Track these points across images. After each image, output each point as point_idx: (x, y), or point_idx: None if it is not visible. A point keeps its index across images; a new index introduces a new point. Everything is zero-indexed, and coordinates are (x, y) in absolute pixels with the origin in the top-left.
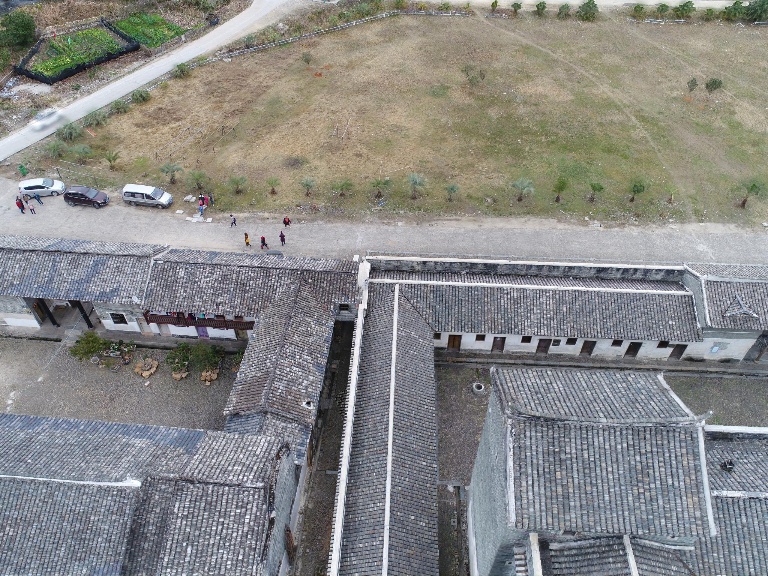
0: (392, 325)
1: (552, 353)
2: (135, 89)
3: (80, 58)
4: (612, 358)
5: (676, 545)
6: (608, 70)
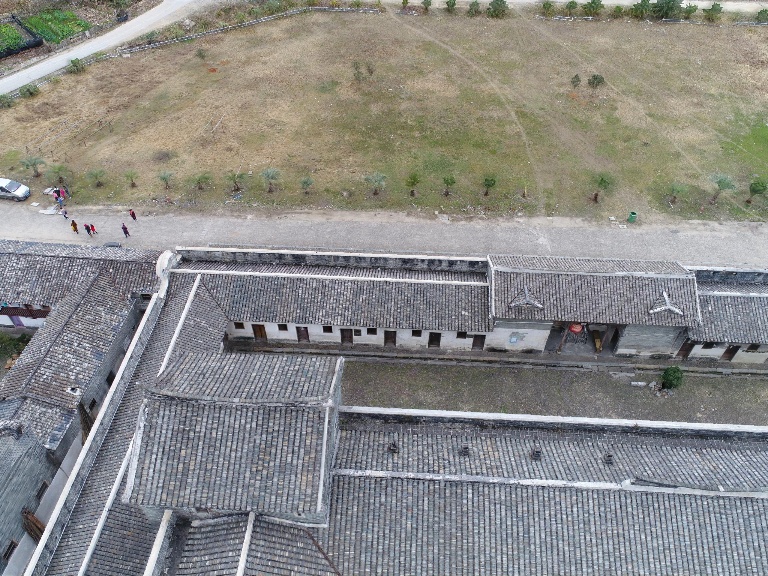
0: (182, 314)
1: (357, 343)
2: (26, 84)
3: None
4: (417, 348)
5: (308, 523)
6: (502, 66)
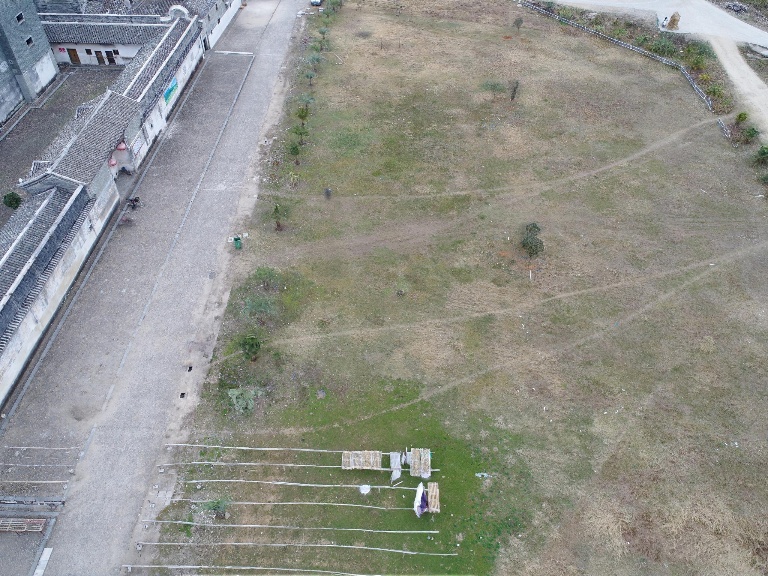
0: None
1: None
2: None
3: None
4: None
5: None
6: (594, 196)
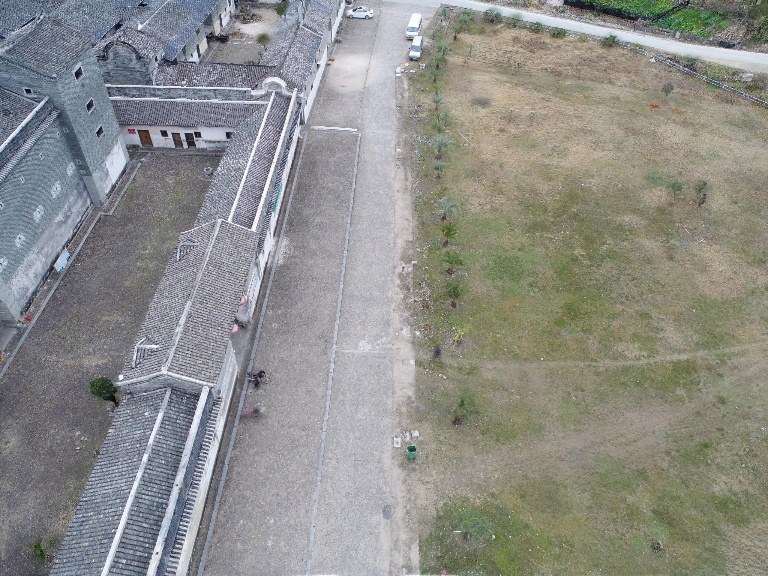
0: None
1: None
2: (570, 30)
3: (613, 6)
4: None
5: None
6: None
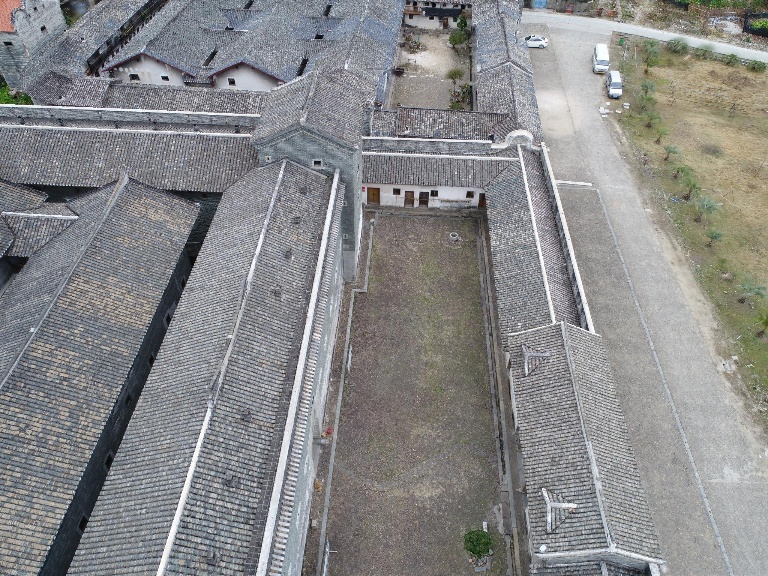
0: None
1: None
2: (767, 63)
3: None
4: None
5: None
6: None
